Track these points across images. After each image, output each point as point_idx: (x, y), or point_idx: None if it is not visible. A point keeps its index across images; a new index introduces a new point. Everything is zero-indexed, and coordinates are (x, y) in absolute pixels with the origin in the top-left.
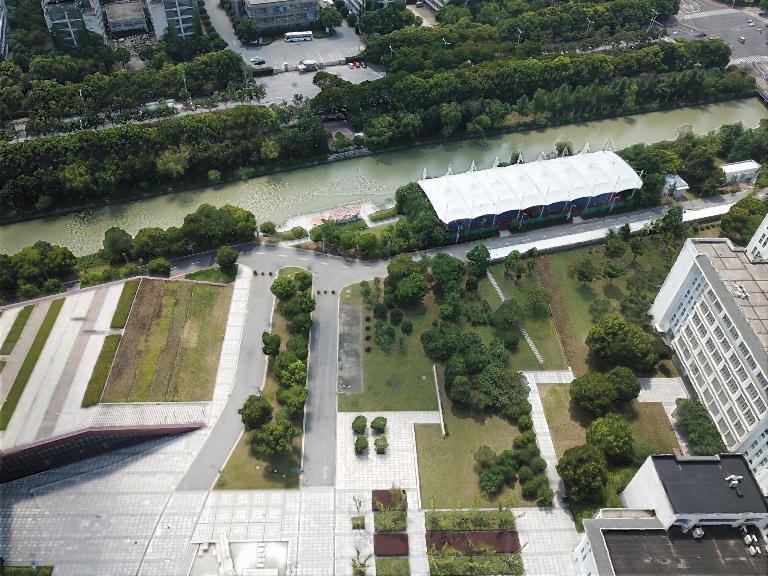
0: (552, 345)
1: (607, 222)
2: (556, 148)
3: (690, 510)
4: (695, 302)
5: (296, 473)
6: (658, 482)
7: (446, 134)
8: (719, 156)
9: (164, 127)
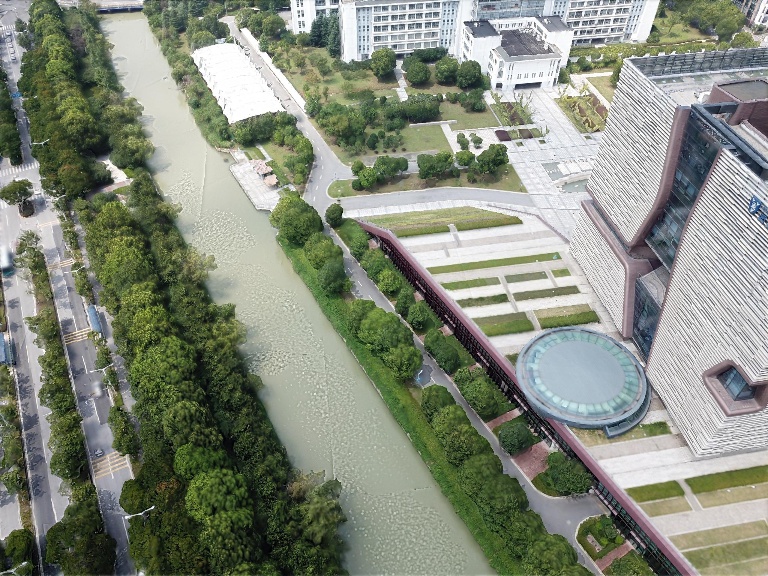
0: (378, 93)
1: (259, 71)
2: (178, 75)
3: (495, 34)
4: (368, 26)
5: (503, 165)
6: (485, 39)
7: (141, 124)
8: (183, 31)
9: (137, 272)
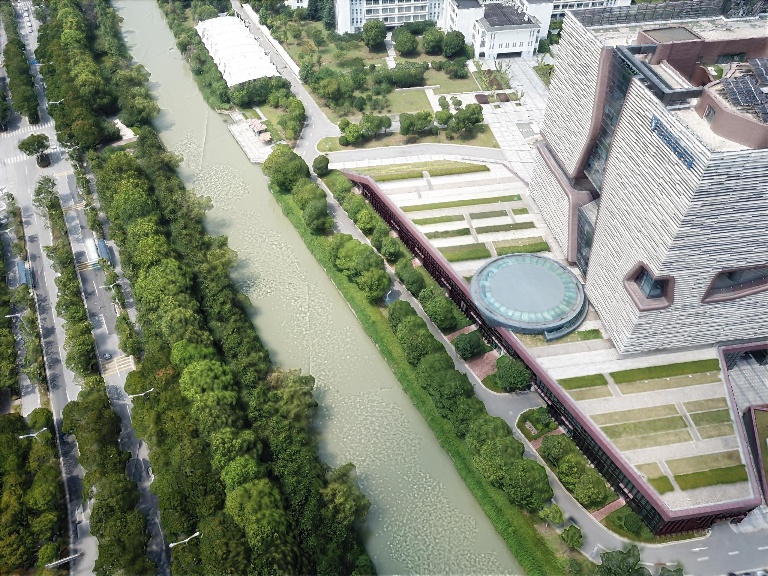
0: None
1: None
2: (182, 45)
3: None
4: None
5: (480, 125)
6: (469, 10)
7: None
8: (189, 6)
9: (142, 208)
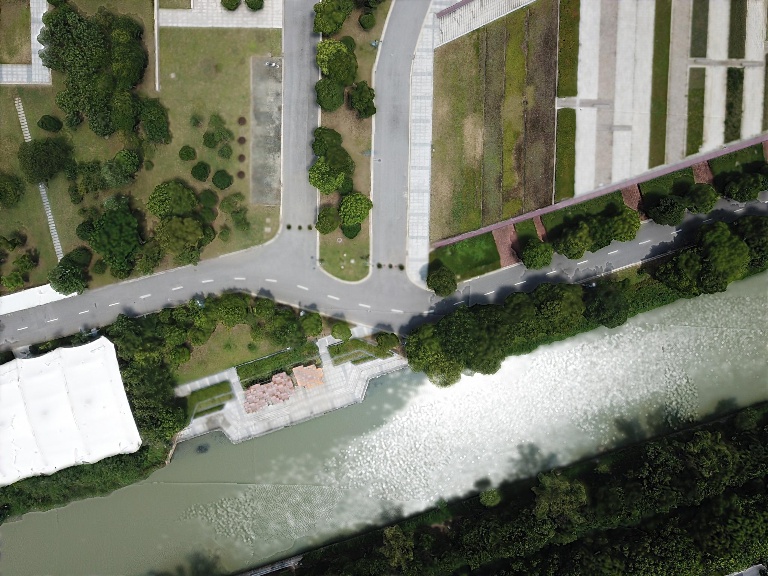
0: None
1: None
2: None
3: None
4: None
5: None
6: None
7: None
8: None
9: None
